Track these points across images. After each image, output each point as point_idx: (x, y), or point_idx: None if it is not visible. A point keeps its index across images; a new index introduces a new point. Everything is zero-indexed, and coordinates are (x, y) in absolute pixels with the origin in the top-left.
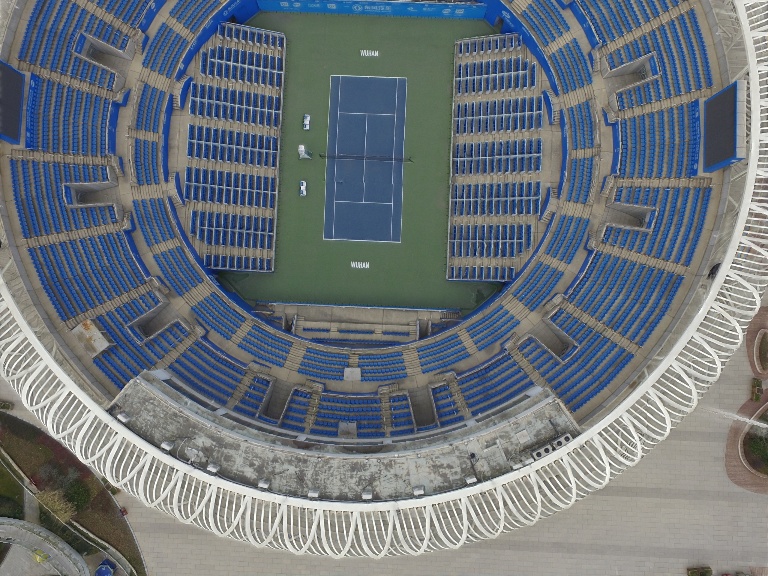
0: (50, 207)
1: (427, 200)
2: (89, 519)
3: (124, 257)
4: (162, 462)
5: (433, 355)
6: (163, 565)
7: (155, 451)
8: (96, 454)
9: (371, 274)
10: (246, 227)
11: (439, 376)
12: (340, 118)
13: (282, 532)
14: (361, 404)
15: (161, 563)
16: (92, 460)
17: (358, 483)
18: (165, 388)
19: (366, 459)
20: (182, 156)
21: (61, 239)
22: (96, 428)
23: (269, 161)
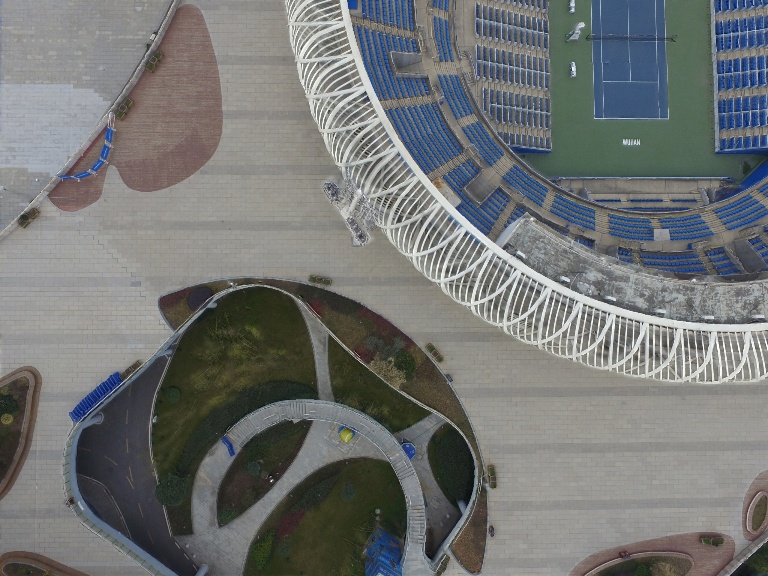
0: (382, 74)
1: (691, 77)
2: (414, 388)
3: (441, 127)
4: (561, 295)
5: (733, 214)
6: (490, 428)
7: (555, 284)
8: (496, 291)
9: (642, 151)
10: (527, 106)
11: (746, 231)
12: (602, 1)
13: (681, 355)
14: (680, 259)
15: (488, 426)
16: (491, 298)
17: (744, 307)
18: (548, 229)
19: (750, 284)
20: (468, 36)
21: (394, 105)
22: (494, 266)
23: (541, 43)
